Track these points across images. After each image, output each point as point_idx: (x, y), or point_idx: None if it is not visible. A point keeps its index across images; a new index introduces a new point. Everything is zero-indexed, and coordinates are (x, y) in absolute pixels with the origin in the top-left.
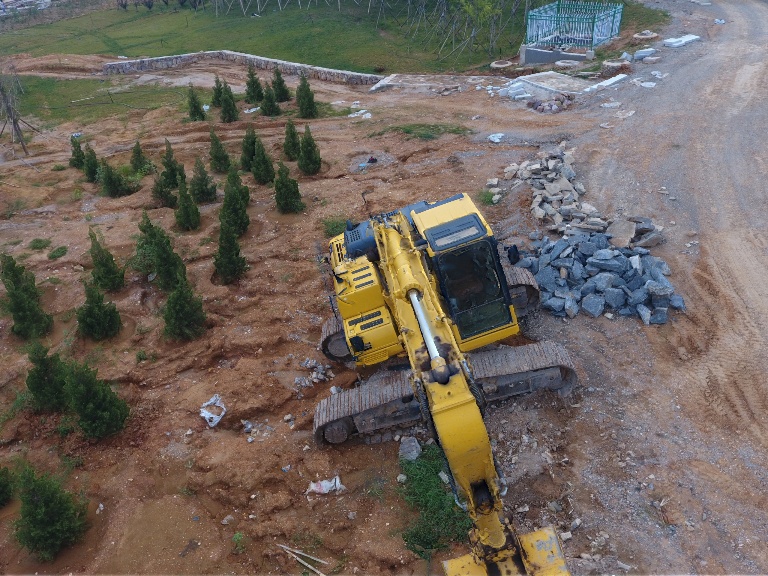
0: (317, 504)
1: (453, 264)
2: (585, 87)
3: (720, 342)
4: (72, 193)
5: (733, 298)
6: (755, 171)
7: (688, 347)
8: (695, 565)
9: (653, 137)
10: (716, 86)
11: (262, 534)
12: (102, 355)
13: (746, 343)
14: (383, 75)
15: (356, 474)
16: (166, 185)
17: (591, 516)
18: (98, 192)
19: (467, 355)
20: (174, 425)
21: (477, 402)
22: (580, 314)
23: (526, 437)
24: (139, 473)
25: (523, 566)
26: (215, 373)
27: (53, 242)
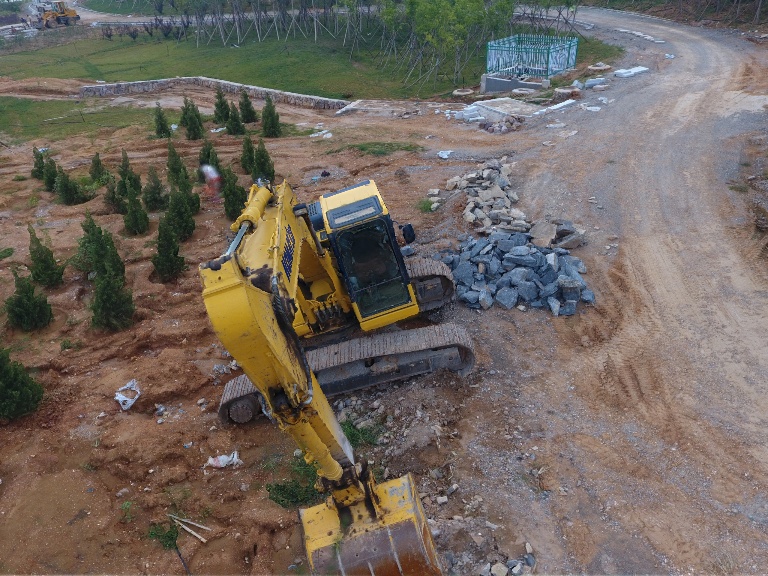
0: (213, 478)
1: (359, 247)
2: (536, 111)
3: (623, 331)
4: (28, 200)
5: (642, 293)
6: (682, 184)
7: (592, 336)
8: (561, 525)
9: (591, 154)
10: (657, 111)
11: (153, 504)
12: (28, 344)
13: (647, 332)
14: (350, 100)
15: (255, 450)
16: (121, 194)
17: (469, 482)
18: (54, 200)
19: (280, 273)
20: (88, 408)
21: (279, 310)
22: (494, 306)
23: (419, 412)
24: (43, 450)
25: (374, 510)
26: (136, 360)
27: (1, 244)
